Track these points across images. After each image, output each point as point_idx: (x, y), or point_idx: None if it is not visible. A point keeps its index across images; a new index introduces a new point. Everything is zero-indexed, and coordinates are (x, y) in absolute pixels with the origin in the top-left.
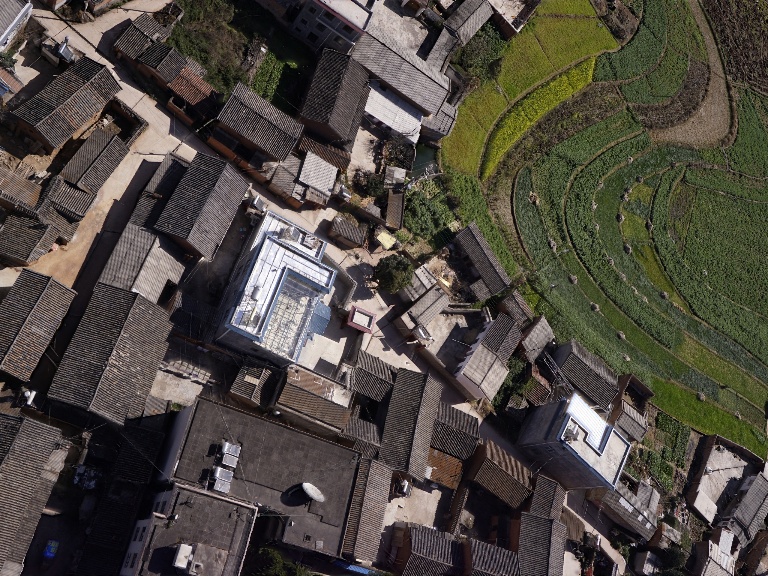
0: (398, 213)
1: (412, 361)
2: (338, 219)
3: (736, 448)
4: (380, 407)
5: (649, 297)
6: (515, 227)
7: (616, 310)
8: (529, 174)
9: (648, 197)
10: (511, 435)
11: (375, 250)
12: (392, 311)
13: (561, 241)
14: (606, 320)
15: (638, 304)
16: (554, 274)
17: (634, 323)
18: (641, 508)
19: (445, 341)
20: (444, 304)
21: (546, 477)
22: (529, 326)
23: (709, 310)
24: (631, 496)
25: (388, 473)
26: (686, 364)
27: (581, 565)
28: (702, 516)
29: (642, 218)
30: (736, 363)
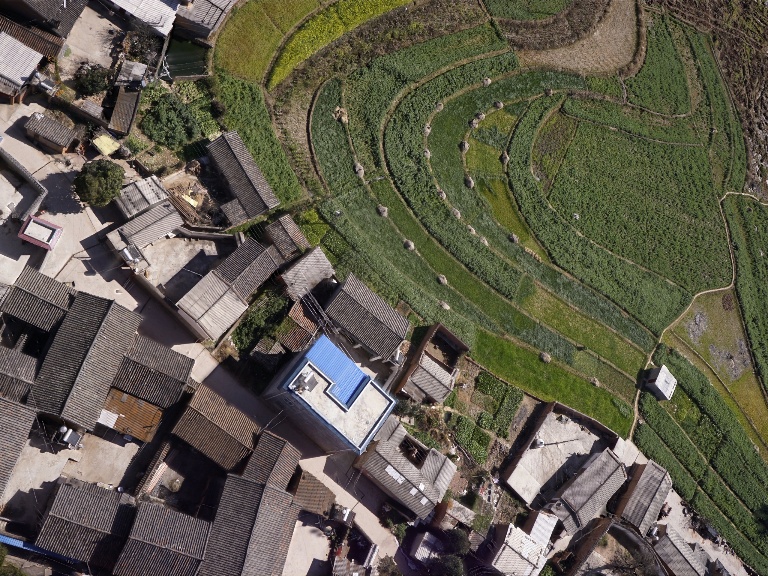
0: (128, 114)
1: (125, 289)
2: (38, 115)
3: (584, 419)
4: (51, 338)
5: (492, 239)
6: (309, 146)
7: (441, 251)
8: (338, 87)
9: (509, 126)
10: (257, 385)
11: (95, 157)
12: (107, 229)
13: (374, 167)
14: (423, 261)
15: (473, 246)
16: (356, 203)
17: (464, 267)
18: (417, 480)
19: (181, 270)
20: (174, 224)
21: (273, 434)
22: (298, 258)
23: (575, 259)
24: (405, 465)
25: (28, 415)
26: (532, 319)
27: (330, 544)
28: (518, 495)
29: (496, 149)
30: (604, 322)
